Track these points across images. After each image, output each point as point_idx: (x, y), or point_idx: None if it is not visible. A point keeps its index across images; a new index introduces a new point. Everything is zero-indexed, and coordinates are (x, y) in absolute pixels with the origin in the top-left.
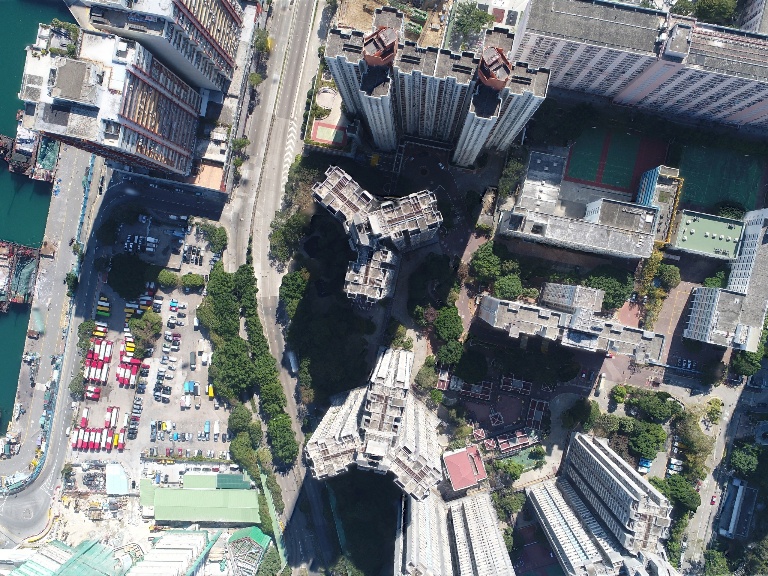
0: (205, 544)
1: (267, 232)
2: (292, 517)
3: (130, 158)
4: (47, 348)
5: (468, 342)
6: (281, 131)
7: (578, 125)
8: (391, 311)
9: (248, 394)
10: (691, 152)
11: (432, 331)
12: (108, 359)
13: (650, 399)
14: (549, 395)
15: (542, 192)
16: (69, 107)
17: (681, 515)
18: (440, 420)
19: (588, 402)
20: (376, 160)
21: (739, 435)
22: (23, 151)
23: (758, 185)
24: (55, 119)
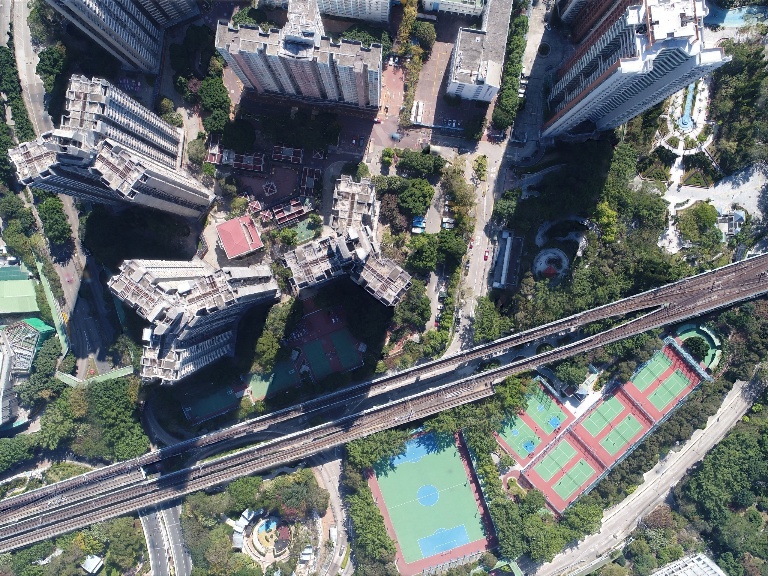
0: None
1: None
2: (75, 307)
3: None
4: None
5: (239, 116)
6: None
7: None
8: (160, 90)
9: None
10: None
11: None
12: None
13: None
14: (323, 164)
15: None
16: None
17: (453, 269)
18: (215, 195)
19: (356, 164)
20: None
21: (506, 190)
22: None
23: None
24: None
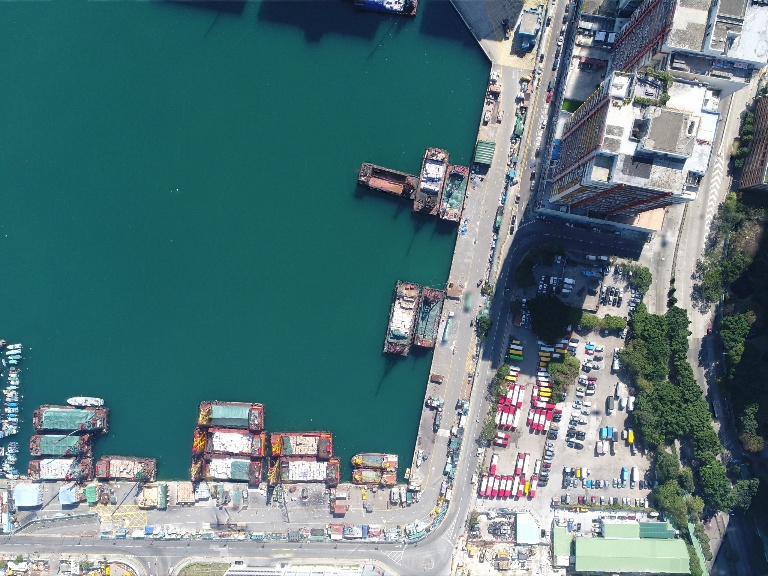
0: None
1: (690, 272)
2: (714, 566)
3: None
4: (451, 393)
5: None
6: None
7: None
8: None
9: (669, 440)
10: None
11: None
12: (521, 404)
13: None
14: None
15: None
16: (652, 159)
17: None
18: None
19: None
20: None
21: None
22: (425, 189)
23: None
24: (636, 171)
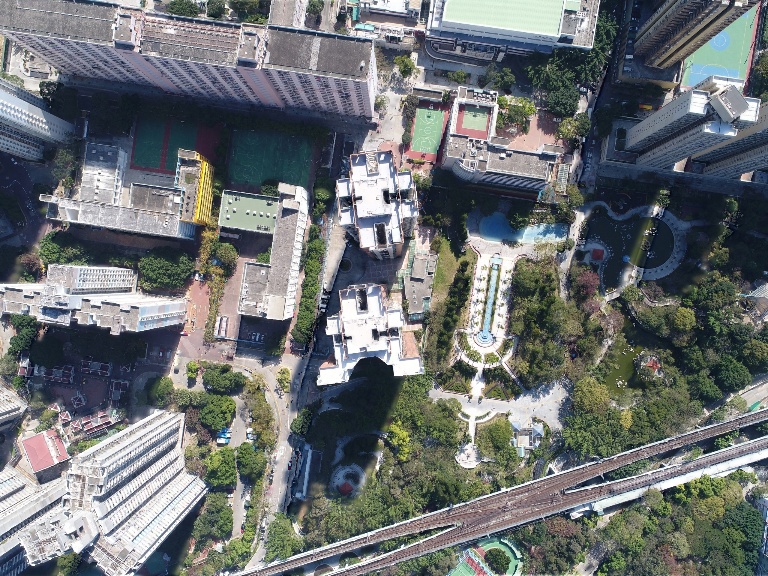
0: None
1: None
2: None
3: None
4: None
5: (51, 329)
6: None
7: (125, 115)
8: None
9: None
10: (245, 136)
11: None
12: None
13: (210, 372)
14: (132, 375)
15: (100, 181)
16: None
17: (254, 481)
18: (26, 406)
19: (160, 379)
20: None
21: (309, 401)
22: None
23: (309, 163)
24: None
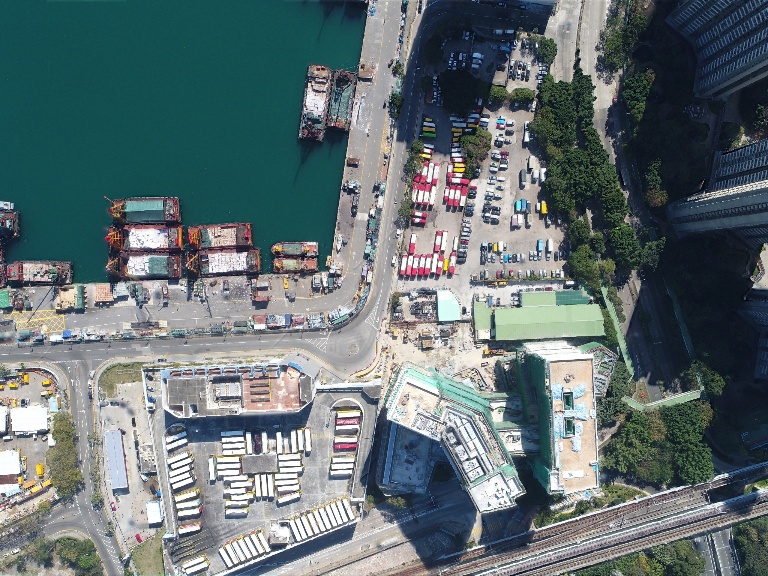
0: None
1: (593, 44)
2: (628, 331)
3: None
4: (367, 176)
5: None
6: None
7: None
8: None
9: (580, 209)
10: None
11: (763, 135)
12: (436, 181)
13: None
14: None
15: None
16: None
17: None
18: None
19: None
20: None
21: None
22: None
23: None
24: None
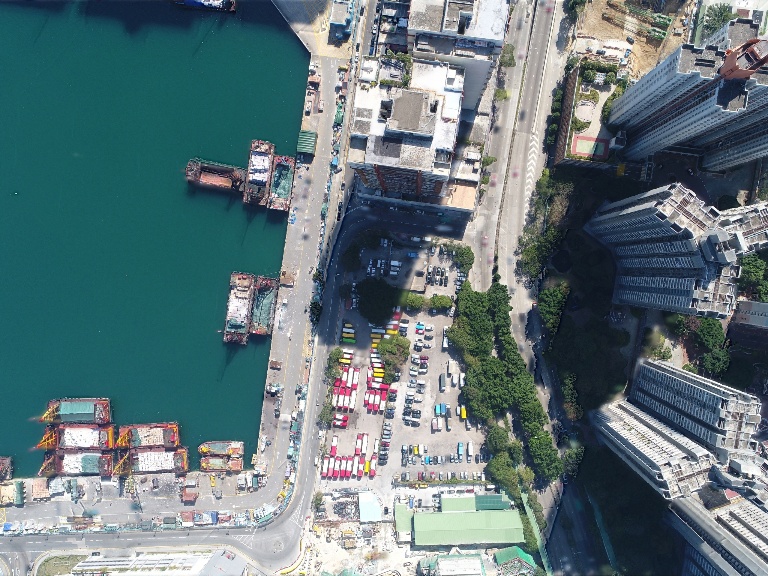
0: (481, 568)
1: (512, 249)
2: (551, 534)
3: (421, 184)
4: (290, 378)
5: None
6: (522, 146)
7: None
8: None
9: (501, 413)
10: None
11: (688, 339)
12: (356, 386)
13: None
14: None
15: None
16: (401, 138)
17: None
18: None
19: None
20: (622, 170)
21: None
22: (255, 181)
23: None
24: (386, 151)
